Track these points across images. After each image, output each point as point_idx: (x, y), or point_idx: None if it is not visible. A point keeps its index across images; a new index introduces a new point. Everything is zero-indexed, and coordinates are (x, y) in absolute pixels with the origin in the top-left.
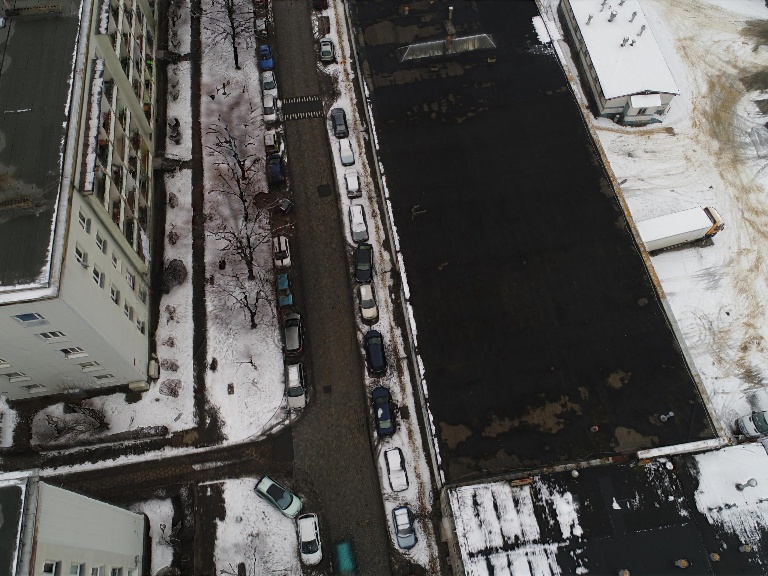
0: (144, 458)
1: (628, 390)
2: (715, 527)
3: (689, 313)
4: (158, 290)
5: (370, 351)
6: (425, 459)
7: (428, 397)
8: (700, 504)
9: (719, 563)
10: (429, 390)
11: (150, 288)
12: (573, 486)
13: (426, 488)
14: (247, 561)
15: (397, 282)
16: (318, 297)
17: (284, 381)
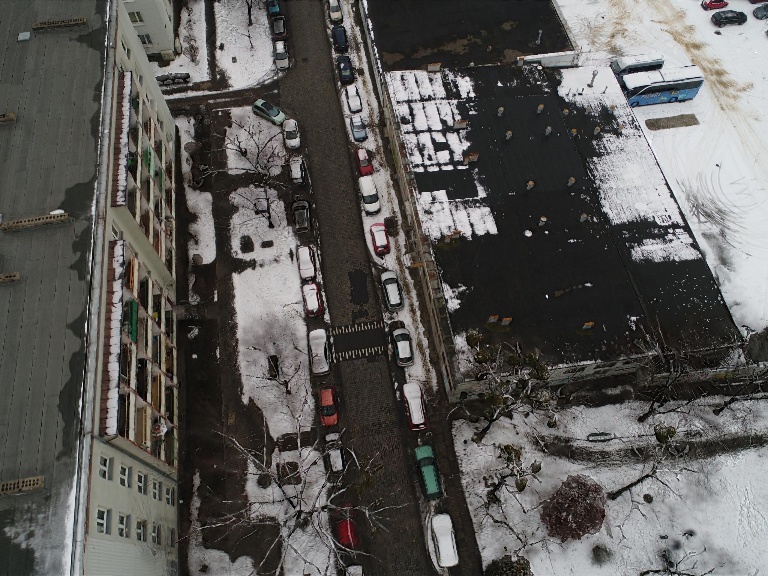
0: (173, 97)
1: (515, 30)
2: (570, 103)
3: (574, 17)
4: (179, 5)
5: (336, 33)
6: (375, 96)
7: (374, 39)
8: (561, 92)
9: (570, 120)
10: (375, 36)
11: (173, 2)
12: (471, 74)
13: (375, 111)
14: (248, 147)
15: (357, 0)
16: (298, 10)
17: (273, 56)
